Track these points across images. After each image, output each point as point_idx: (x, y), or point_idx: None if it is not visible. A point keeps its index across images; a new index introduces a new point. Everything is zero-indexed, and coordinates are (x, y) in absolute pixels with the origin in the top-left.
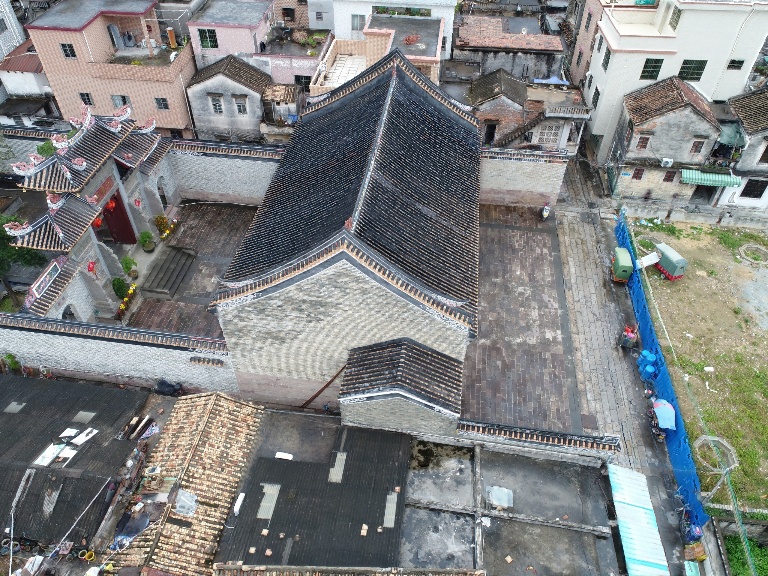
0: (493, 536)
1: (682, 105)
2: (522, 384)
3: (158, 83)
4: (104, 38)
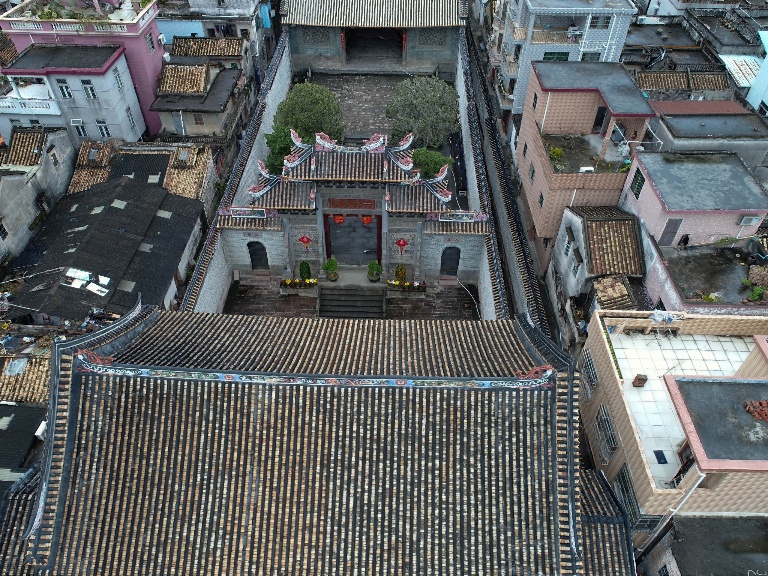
0: None
1: None
2: None
3: None
4: (584, 114)
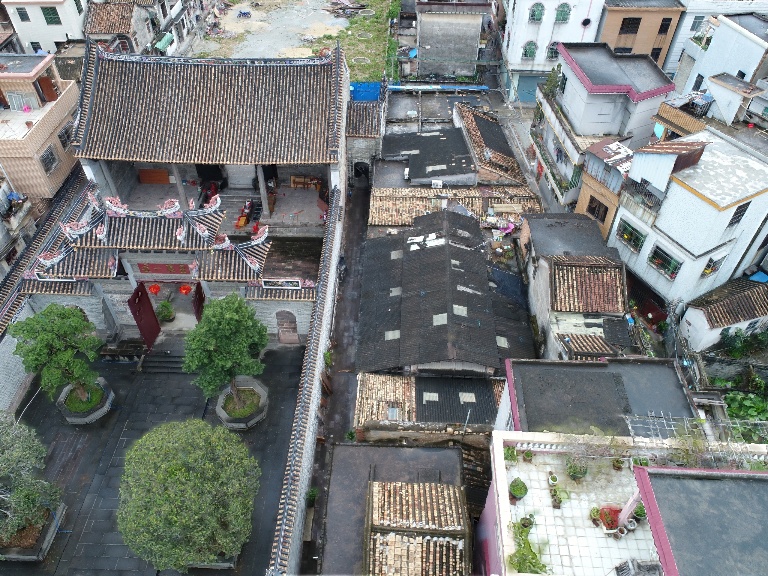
0: None
1: (133, 5)
2: None
3: None
4: None
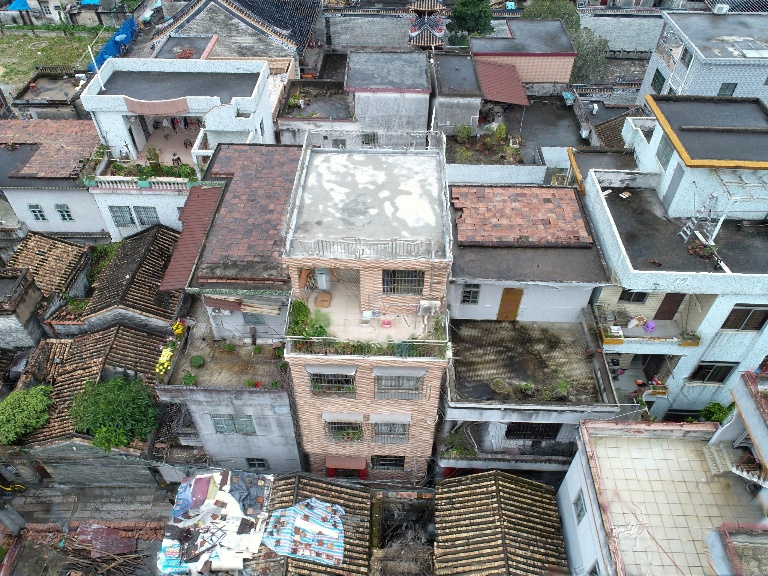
0: None
1: None
2: None
3: None
4: None
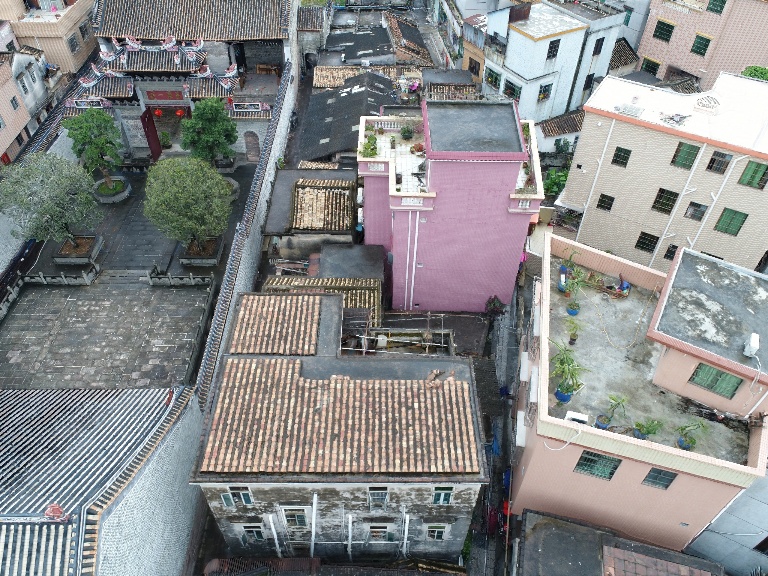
0: None
1: None
2: None
3: (7, 83)
4: None
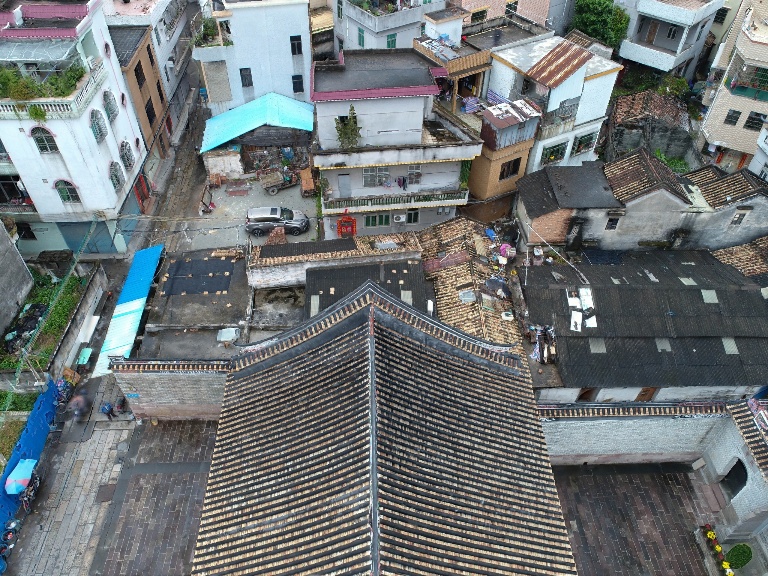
0: (238, 316)
1: None
2: (171, 529)
3: None
4: None
